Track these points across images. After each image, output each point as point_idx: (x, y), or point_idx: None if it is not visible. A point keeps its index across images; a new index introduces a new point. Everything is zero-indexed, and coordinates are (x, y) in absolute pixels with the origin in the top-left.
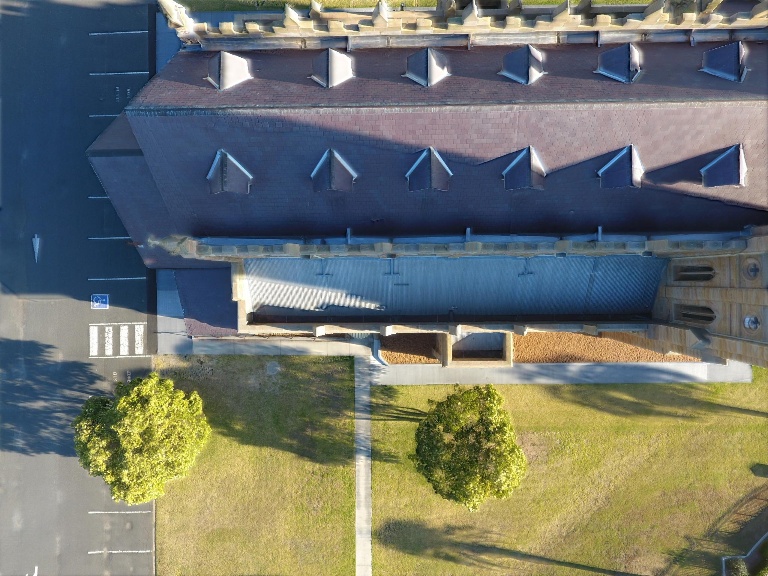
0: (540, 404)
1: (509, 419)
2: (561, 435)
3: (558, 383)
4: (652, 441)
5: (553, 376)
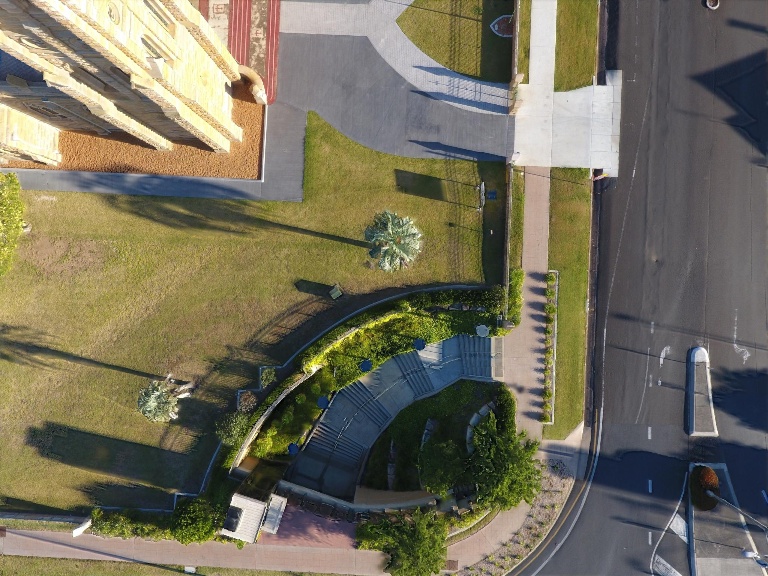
0: (98, 212)
1: (3, 196)
2: (117, 244)
3: (116, 193)
4: (205, 254)
5: (112, 186)
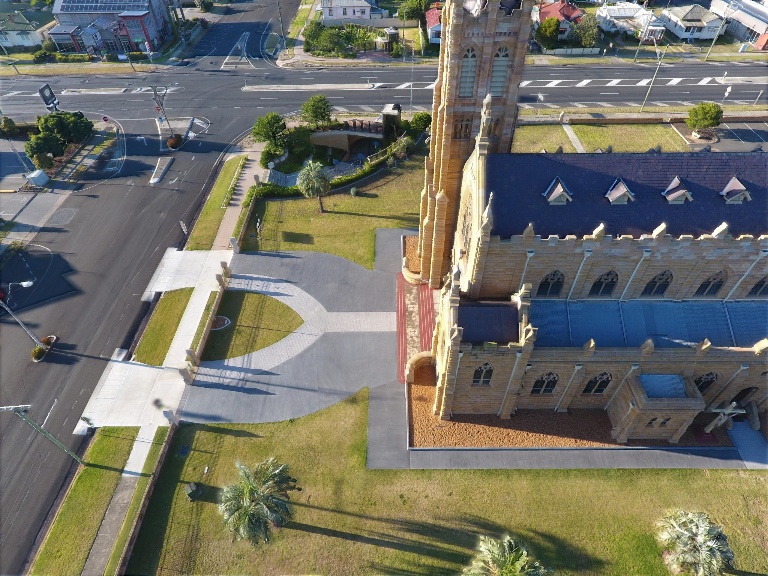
0: None
1: None
2: None
3: None
4: None
5: None
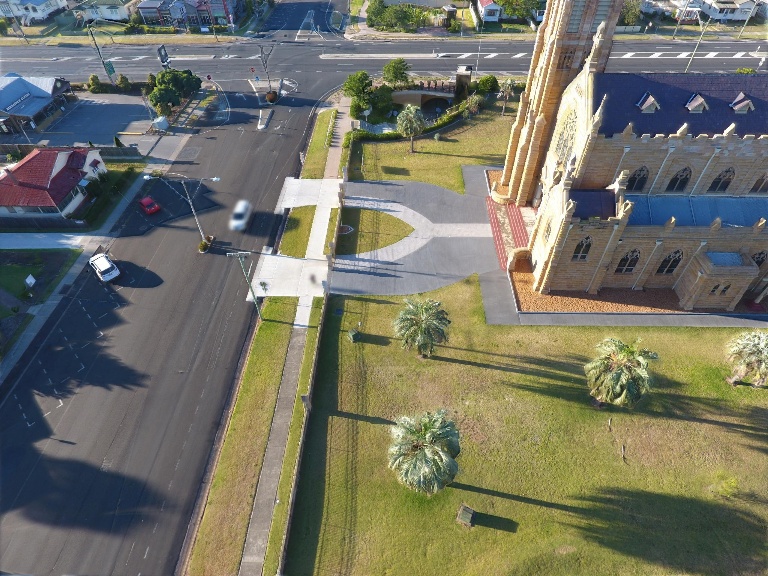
0: None
1: None
2: None
3: None
4: None
5: None
